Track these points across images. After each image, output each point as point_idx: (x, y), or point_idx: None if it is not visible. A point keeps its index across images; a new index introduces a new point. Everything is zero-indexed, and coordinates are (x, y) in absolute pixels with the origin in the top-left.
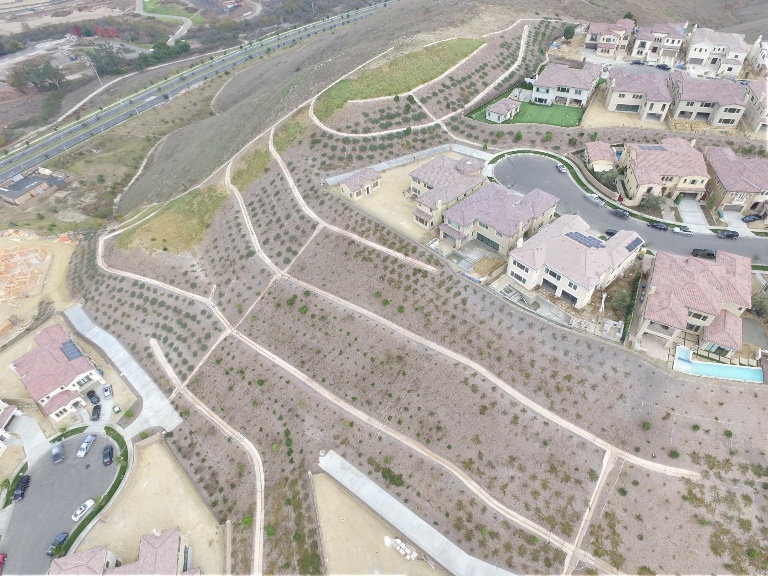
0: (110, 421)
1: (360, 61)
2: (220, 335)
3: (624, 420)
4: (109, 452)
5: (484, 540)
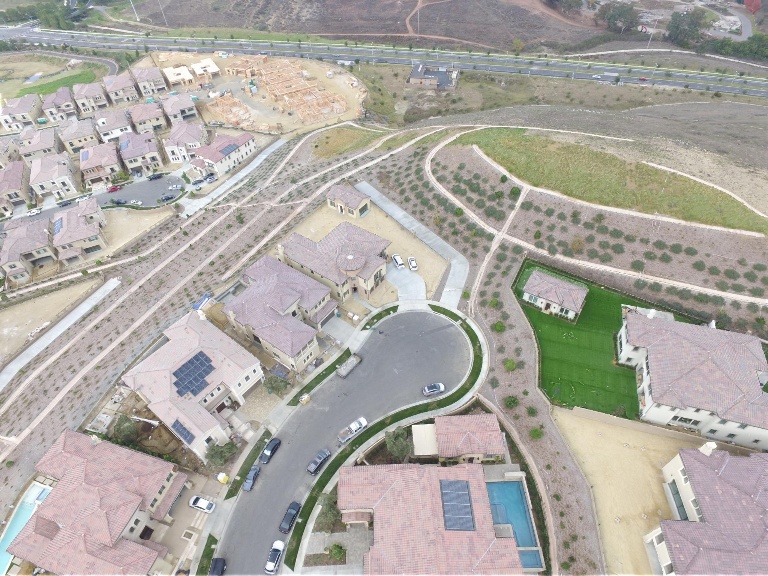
0: (192, 190)
1: (579, 127)
2: (233, 202)
3: (27, 447)
4: (169, 197)
5: (20, 375)
